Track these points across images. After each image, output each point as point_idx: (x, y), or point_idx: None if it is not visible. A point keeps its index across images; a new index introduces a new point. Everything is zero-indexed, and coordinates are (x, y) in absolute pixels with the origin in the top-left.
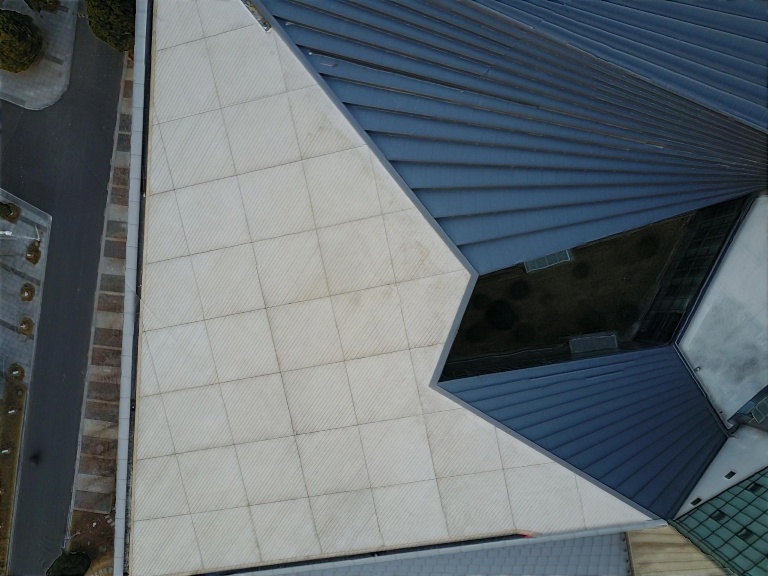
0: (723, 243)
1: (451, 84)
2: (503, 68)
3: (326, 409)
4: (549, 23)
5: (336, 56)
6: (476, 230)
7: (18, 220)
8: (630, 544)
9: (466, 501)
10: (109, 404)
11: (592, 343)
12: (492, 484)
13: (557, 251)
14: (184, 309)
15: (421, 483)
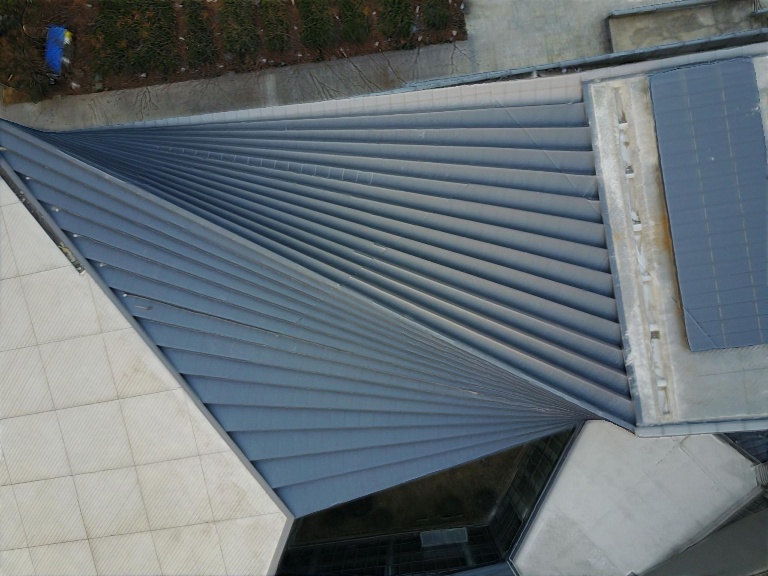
0: (558, 458)
1: (265, 329)
2: (315, 318)
3: None
4: (356, 279)
5: (151, 298)
6: (293, 472)
7: None
8: None
9: None
10: None
11: (442, 536)
12: None
13: None
14: (8, 536)
15: None
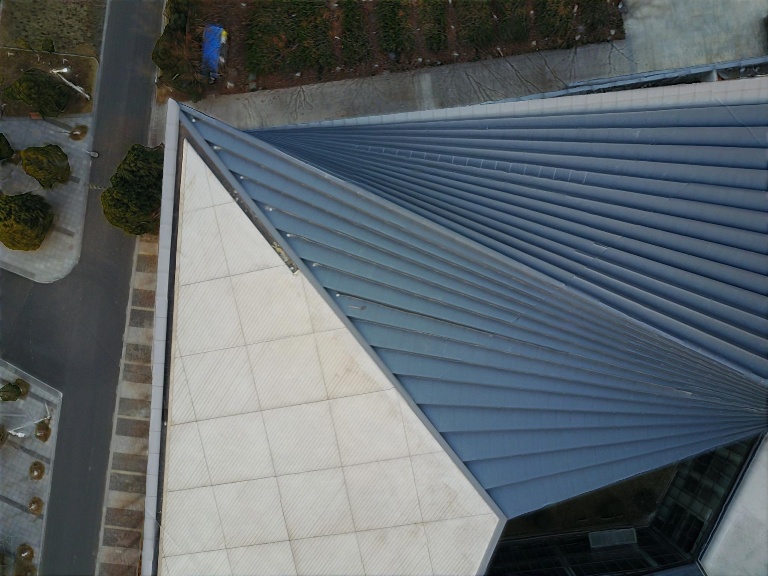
0: (745, 458)
1: (480, 329)
2: (533, 317)
3: None
4: (581, 279)
5: (364, 298)
6: (504, 472)
7: (27, 397)
8: None
9: None
10: None
11: (612, 537)
12: None
13: None
14: (205, 537)
15: None
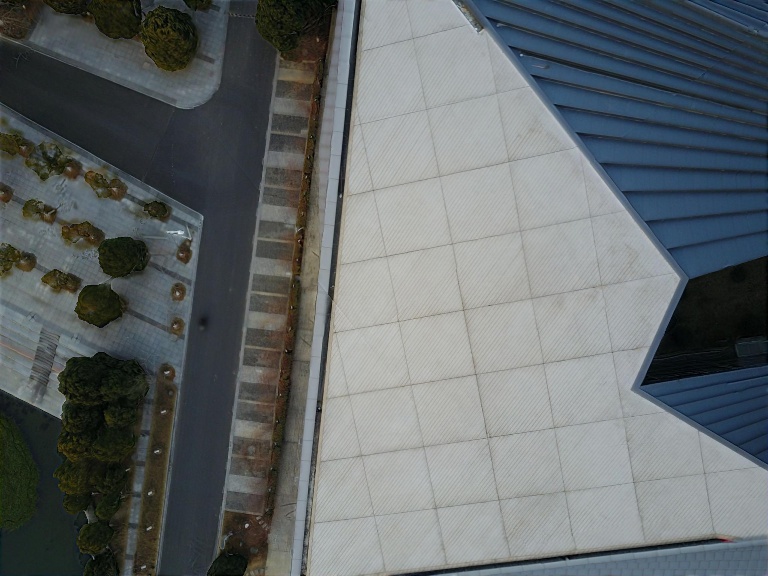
0: None
1: (665, 87)
2: (720, 71)
3: (522, 412)
4: None
5: (548, 58)
6: (685, 233)
7: (169, 219)
8: None
9: (664, 505)
10: (261, 405)
11: (759, 347)
12: (692, 488)
13: (764, 255)
14: (378, 310)
15: (618, 487)
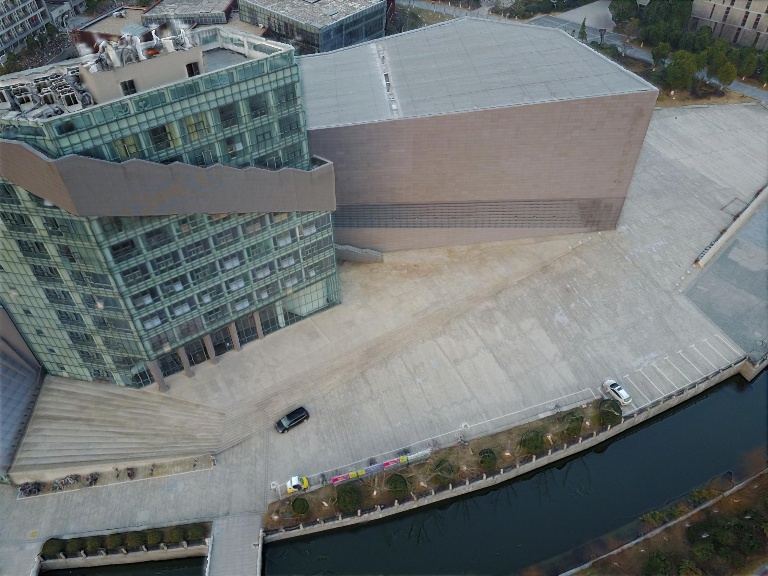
0: None
1: None
2: None
3: None
4: None
5: None
6: None
7: None
8: (34, 414)
9: None
10: None
11: None
12: None
13: None
14: None
15: None
